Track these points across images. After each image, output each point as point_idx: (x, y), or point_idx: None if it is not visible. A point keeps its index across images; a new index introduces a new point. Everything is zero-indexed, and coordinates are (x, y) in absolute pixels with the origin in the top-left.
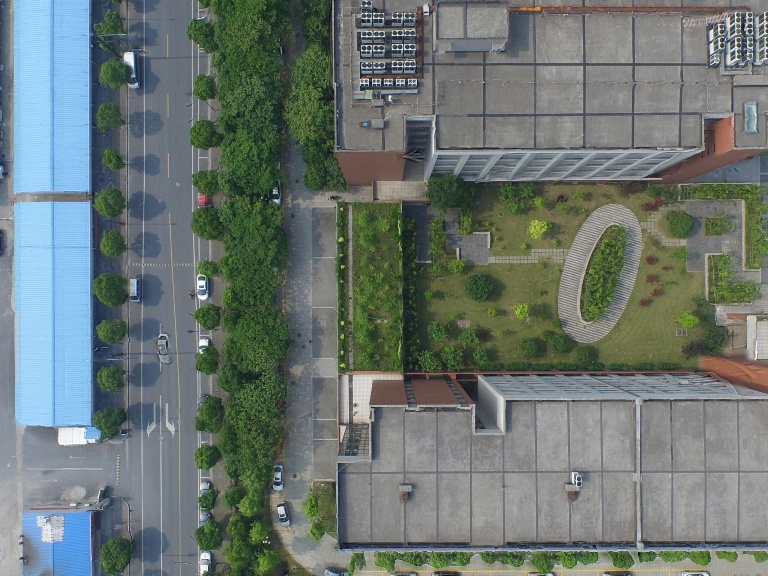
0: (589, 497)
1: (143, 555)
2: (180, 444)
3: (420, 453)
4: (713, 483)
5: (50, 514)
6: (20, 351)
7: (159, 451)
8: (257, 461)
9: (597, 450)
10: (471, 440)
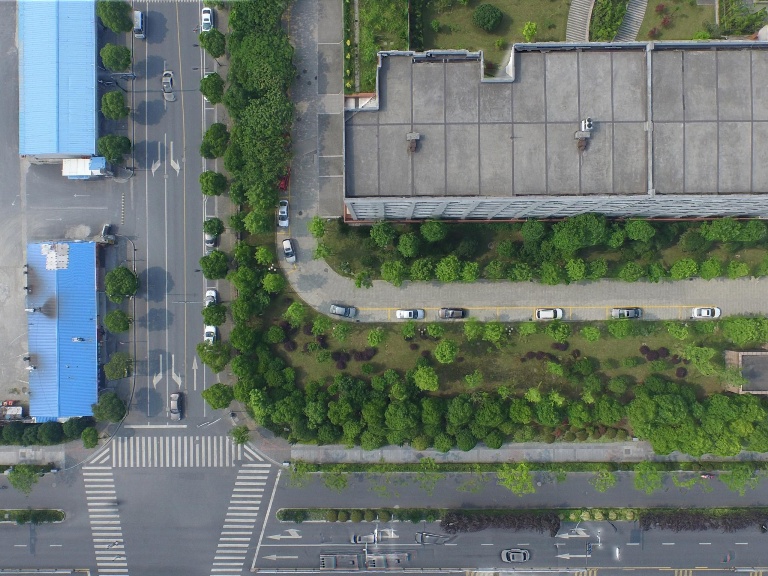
0: (599, 148)
1: (148, 295)
2: (185, 183)
3: (428, 104)
4: (726, 133)
5: (54, 242)
6: (24, 80)
7: (164, 190)
8: (263, 176)
9: (607, 101)
10: (479, 91)
